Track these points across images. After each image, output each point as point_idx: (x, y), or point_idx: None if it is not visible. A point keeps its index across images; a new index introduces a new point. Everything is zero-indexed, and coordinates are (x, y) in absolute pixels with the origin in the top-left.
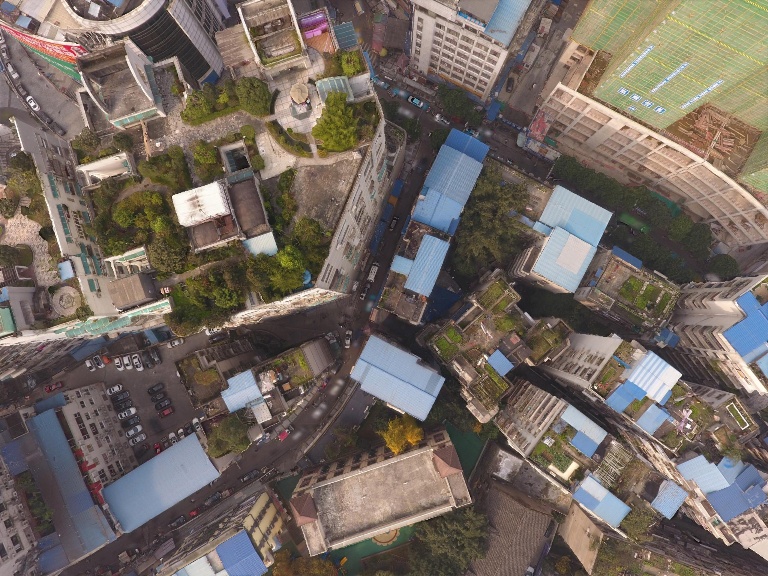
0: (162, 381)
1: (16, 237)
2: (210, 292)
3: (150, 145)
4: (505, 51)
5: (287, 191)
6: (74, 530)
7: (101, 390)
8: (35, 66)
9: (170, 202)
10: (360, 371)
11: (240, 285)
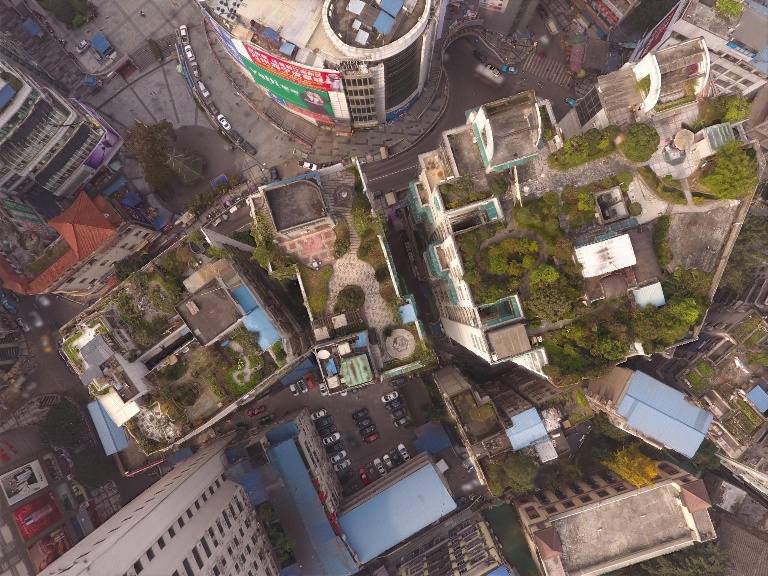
0: (366, 406)
1: (345, 278)
2: (593, 343)
3: (515, 189)
4: (764, 81)
5: (665, 239)
6: (317, 562)
7: (308, 415)
8: (233, 85)
9: (565, 252)
10: (626, 407)
11: (628, 337)
